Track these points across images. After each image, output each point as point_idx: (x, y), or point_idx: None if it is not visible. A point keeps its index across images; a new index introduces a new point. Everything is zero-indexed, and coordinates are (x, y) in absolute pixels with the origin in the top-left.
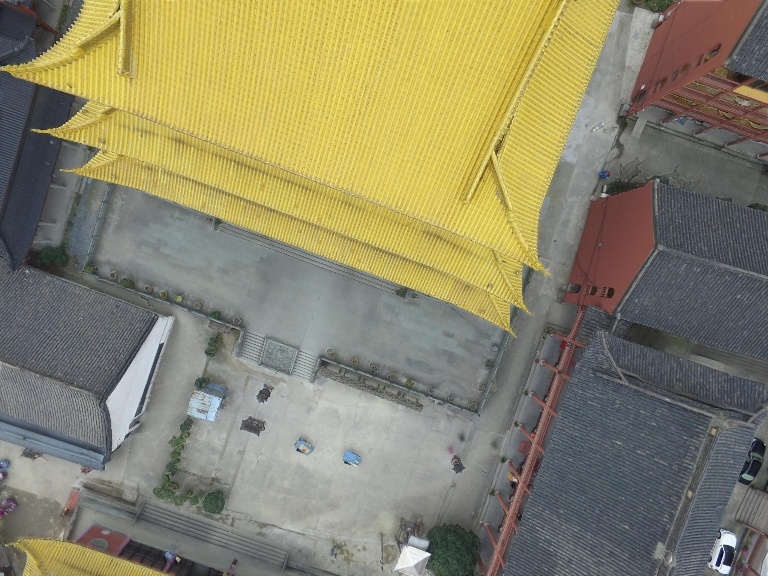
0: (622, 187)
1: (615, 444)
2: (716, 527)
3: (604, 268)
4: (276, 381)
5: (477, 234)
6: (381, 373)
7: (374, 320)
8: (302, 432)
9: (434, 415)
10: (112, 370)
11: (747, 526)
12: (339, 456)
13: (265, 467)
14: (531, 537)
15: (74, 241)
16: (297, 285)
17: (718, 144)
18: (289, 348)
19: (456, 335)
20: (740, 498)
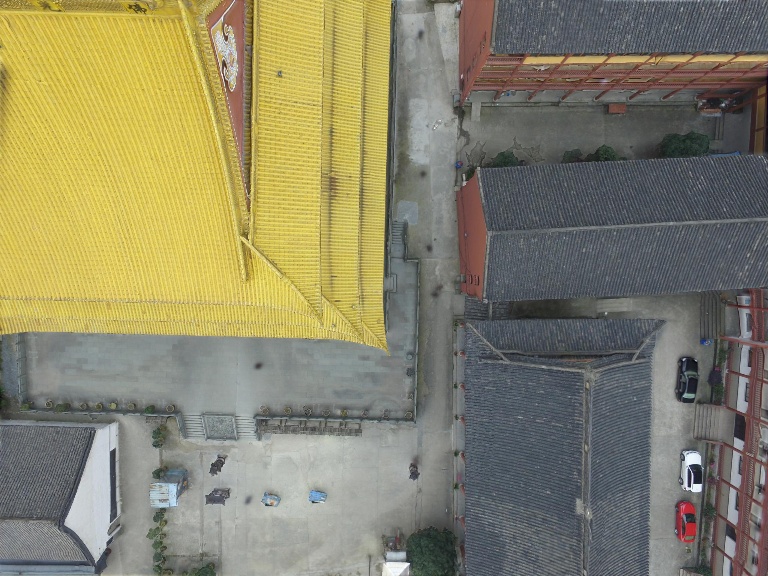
0: None
1: (518, 419)
2: (678, 451)
3: (472, 257)
4: (227, 449)
5: (272, 301)
6: (315, 412)
7: (293, 367)
8: (266, 487)
9: (379, 433)
10: (65, 493)
11: (706, 441)
12: (307, 498)
13: (244, 529)
14: (477, 525)
15: (9, 384)
16: (213, 359)
17: (554, 101)
18: (226, 417)
19: (371, 356)
20: (692, 416)
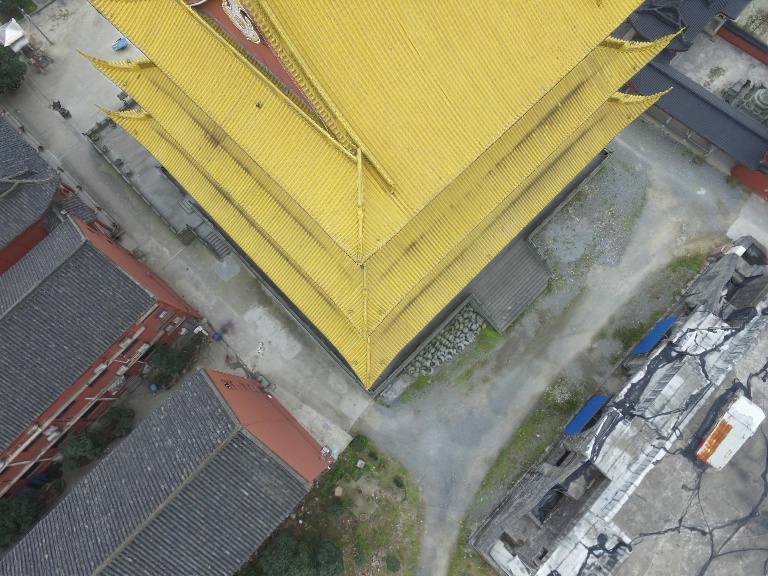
0: (195, 343)
1: None
2: None
3: None
4: None
5: None
6: None
7: None
8: None
9: None
10: None
11: None
12: None
13: None
14: None
15: None
16: None
17: None
18: None
19: None
20: None
